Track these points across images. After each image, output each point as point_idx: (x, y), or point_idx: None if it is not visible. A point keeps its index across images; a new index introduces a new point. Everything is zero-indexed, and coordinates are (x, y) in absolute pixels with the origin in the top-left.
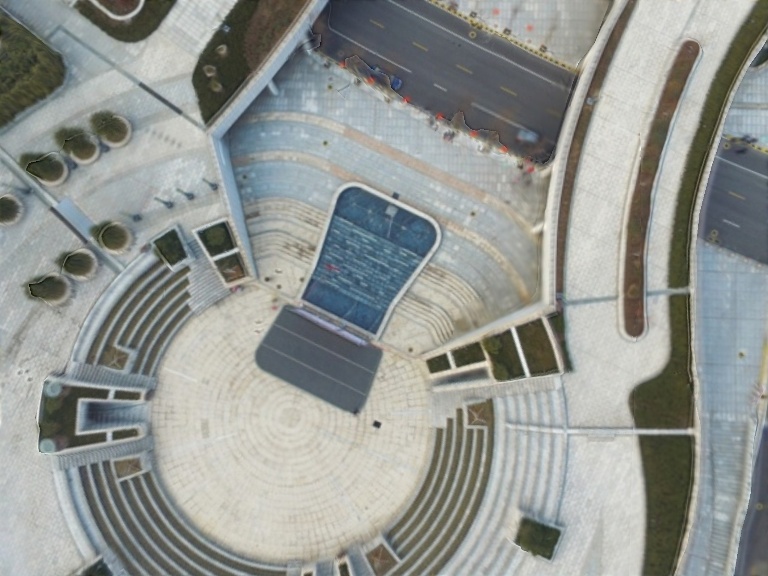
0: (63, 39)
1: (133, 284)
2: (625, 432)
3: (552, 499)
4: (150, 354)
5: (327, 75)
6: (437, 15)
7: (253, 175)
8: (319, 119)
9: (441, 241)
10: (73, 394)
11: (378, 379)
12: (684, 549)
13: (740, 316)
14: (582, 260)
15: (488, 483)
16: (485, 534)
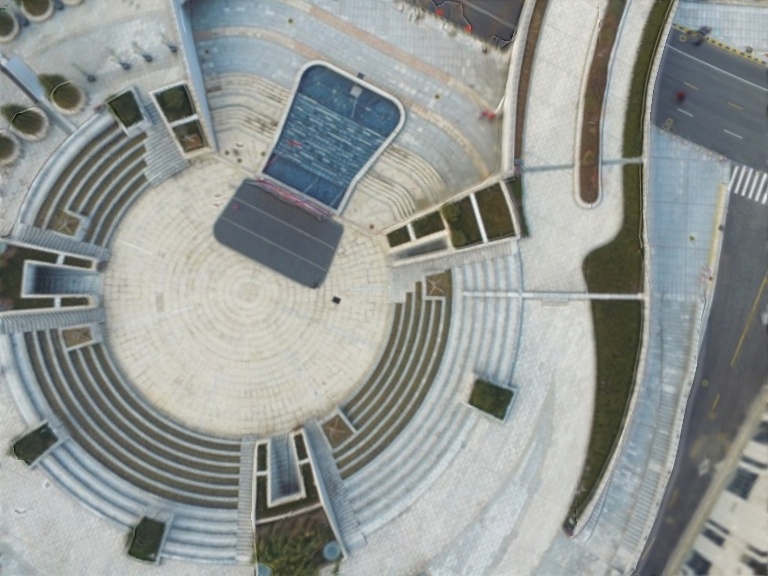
0: None
1: (86, 146)
2: (578, 296)
3: (506, 361)
4: (103, 224)
5: None
6: None
7: (215, 50)
8: None
9: (405, 122)
10: (19, 255)
11: (338, 255)
12: (632, 409)
13: (691, 201)
14: (541, 128)
15: (445, 352)
16: (440, 400)
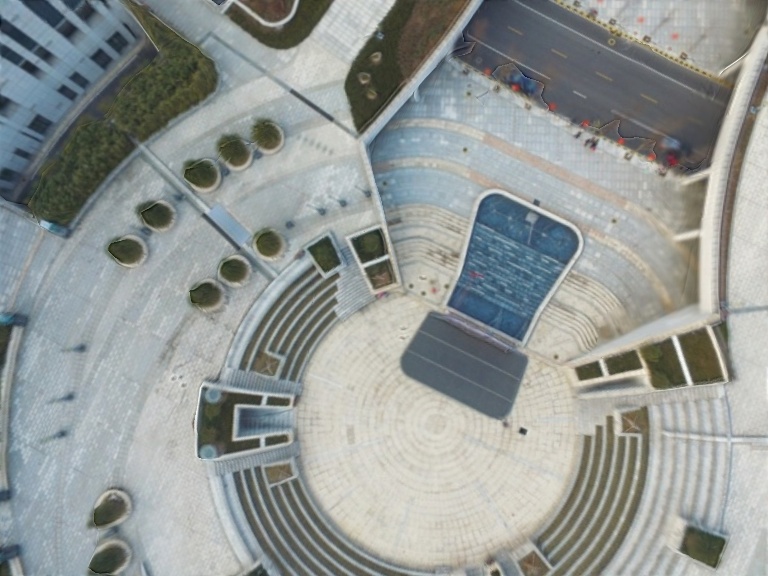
0: (214, 46)
1: (286, 290)
2: None
3: (716, 507)
4: (297, 360)
5: (466, 82)
6: (576, 22)
7: (393, 181)
8: (458, 126)
9: (583, 248)
10: (230, 400)
11: (524, 386)
12: None
13: None
14: (744, 269)
15: (644, 491)
16: (643, 542)
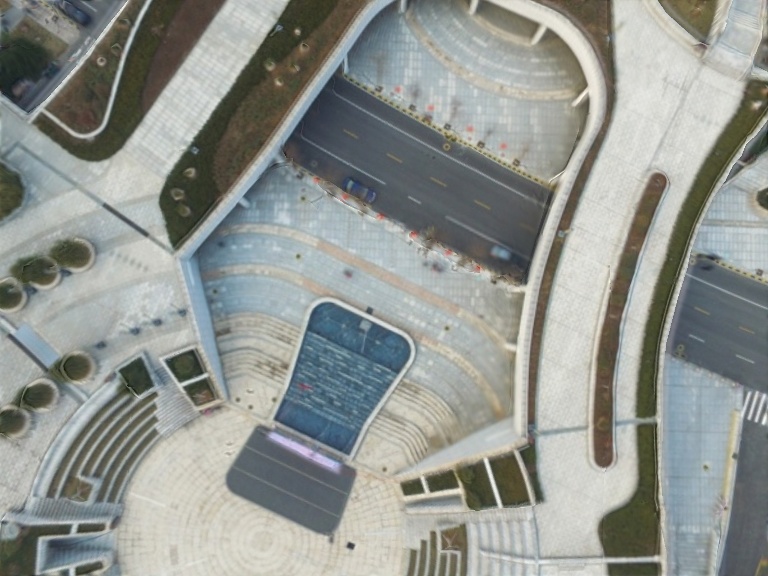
0: (21, 157)
1: (97, 413)
2: (595, 561)
3: None
4: (116, 481)
5: (300, 186)
6: (411, 126)
7: (224, 289)
8: (292, 231)
9: (415, 357)
10: (33, 533)
11: (352, 500)
12: None
13: (704, 429)
14: (553, 391)
15: None
16: None
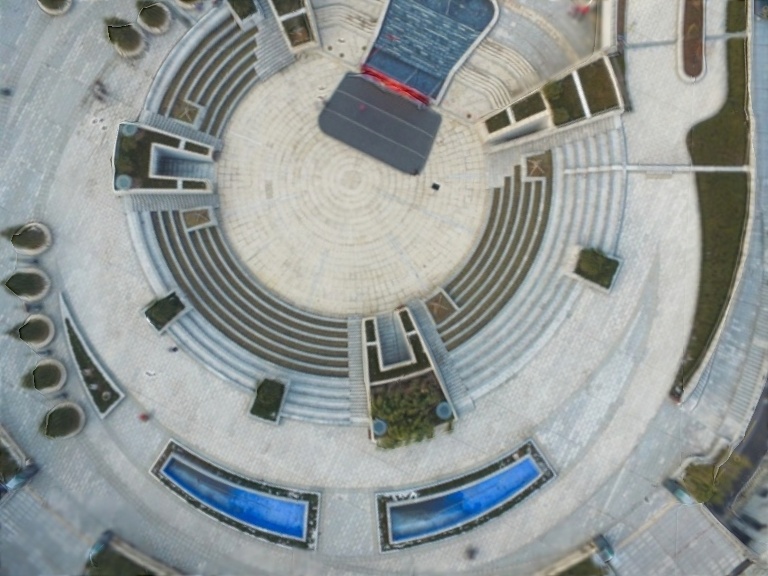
0: None
1: (204, 39)
2: (683, 169)
3: (611, 233)
4: (217, 115)
5: None
6: None
7: None
8: None
9: (499, 17)
10: (147, 138)
11: (437, 144)
12: (739, 280)
13: None
14: (643, 5)
15: (546, 229)
16: (543, 275)
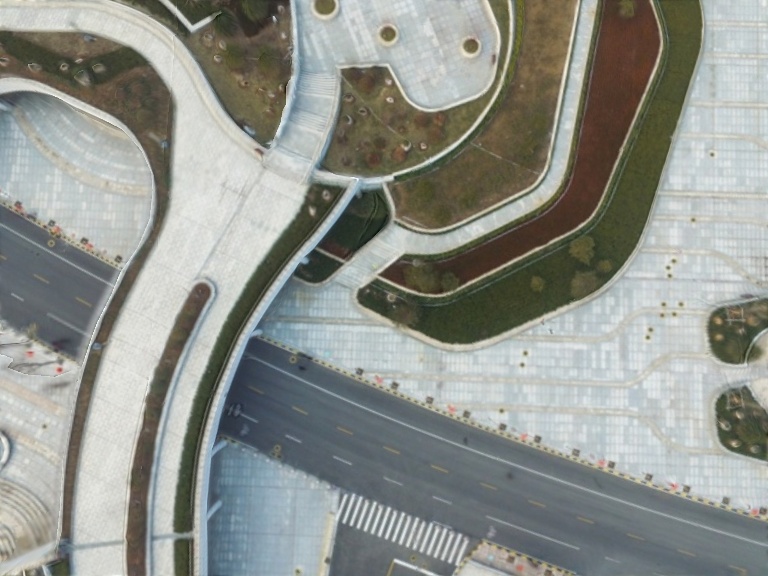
0: None
1: None
2: None
3: None
4: None
5: None
6: (17, 223)
7: None
8: None
9: (9, 455)
10: None
11: None
12: None
13: (298, 533)
14: (90, 504)
15: None
16: None
